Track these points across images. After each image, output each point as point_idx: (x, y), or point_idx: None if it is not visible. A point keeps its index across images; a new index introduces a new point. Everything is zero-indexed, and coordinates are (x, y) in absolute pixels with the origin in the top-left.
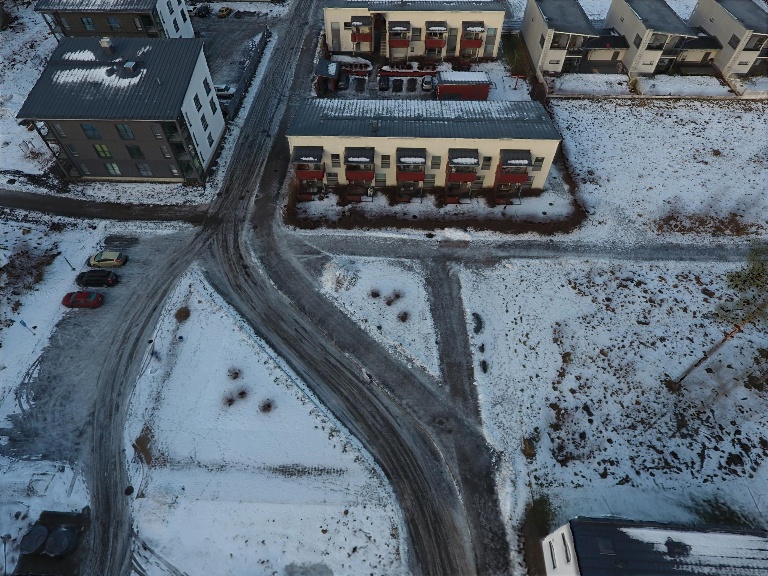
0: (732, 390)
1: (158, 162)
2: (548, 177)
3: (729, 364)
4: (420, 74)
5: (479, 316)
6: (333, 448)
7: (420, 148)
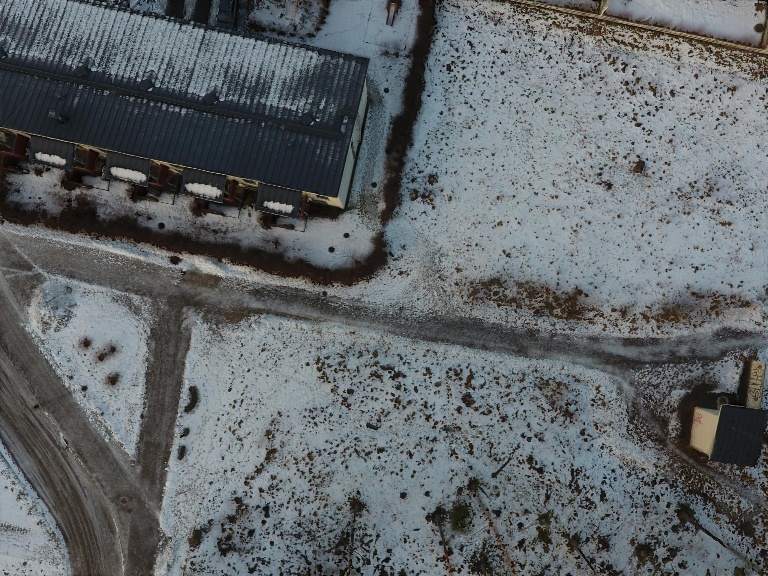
0: (411, 519)
1: None
2: (364, 182)
3: (429, 491)
4: None
5: (197, 391)
6: (19, 509)
7: None
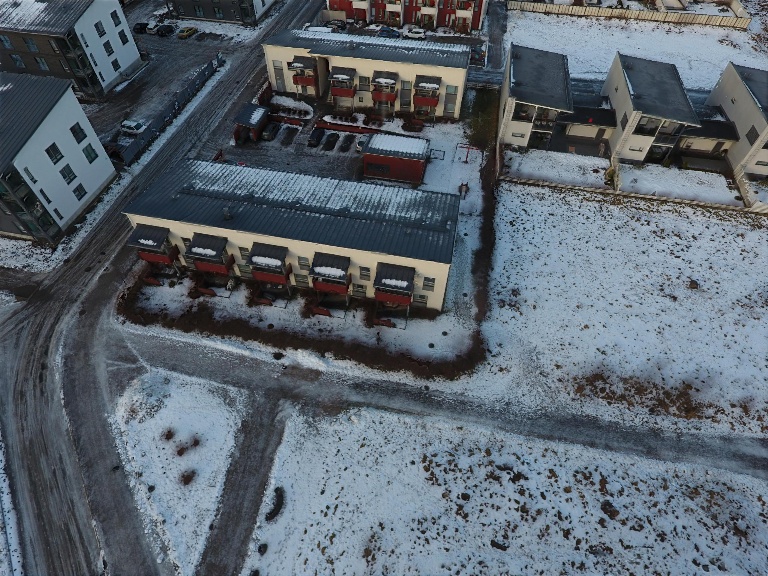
0: None
1: (1, 217)
2: (456, 293)
3: None
4: (361, 131)
5: (283, 493)
6: None
7: (281, 246)
